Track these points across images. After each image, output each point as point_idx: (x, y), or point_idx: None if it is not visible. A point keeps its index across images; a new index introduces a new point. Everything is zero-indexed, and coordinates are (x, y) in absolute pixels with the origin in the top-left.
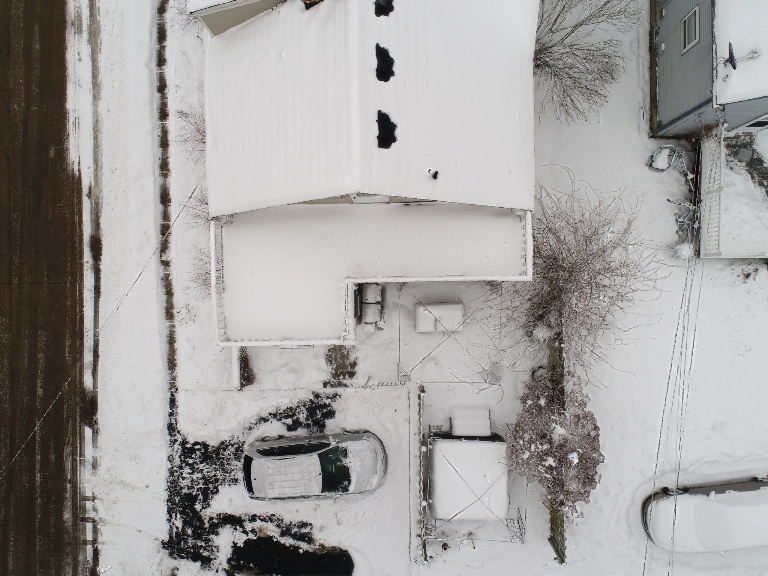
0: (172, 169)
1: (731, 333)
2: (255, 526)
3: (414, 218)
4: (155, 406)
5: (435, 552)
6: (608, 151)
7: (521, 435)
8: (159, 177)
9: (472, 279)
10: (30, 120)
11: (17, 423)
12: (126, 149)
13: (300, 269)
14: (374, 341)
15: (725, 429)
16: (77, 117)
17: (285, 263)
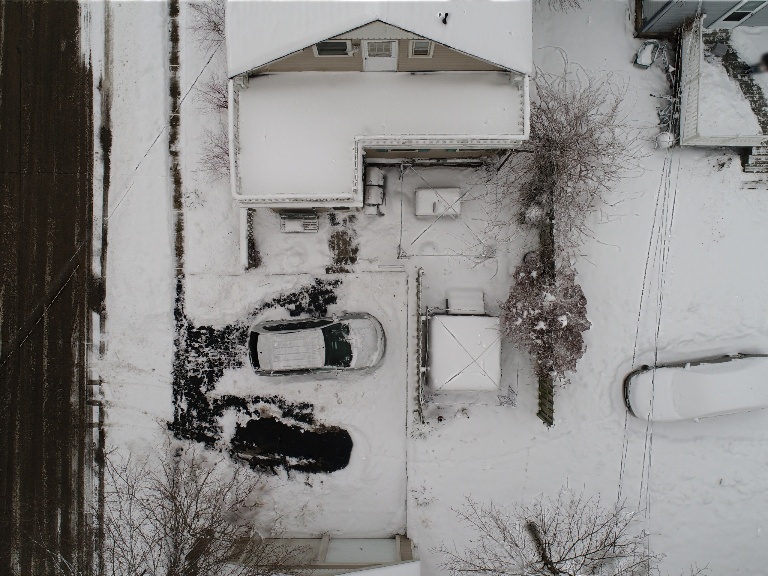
0: (182, 62)
1: (707, 220)
2: (258, 407)
3: (420, 85)
4: (163, 290)
5: (431, 426)
6: (596, 49)
7: (514, 305)
8: (169, 70)
9: (474, 137)
10: (42, 14)
11: (25, 309)
12: (137, 42)
13: (312, 132)
14: (375, 227)
15: (700, 310)
16: (89, 12)
17: (298, 126)
